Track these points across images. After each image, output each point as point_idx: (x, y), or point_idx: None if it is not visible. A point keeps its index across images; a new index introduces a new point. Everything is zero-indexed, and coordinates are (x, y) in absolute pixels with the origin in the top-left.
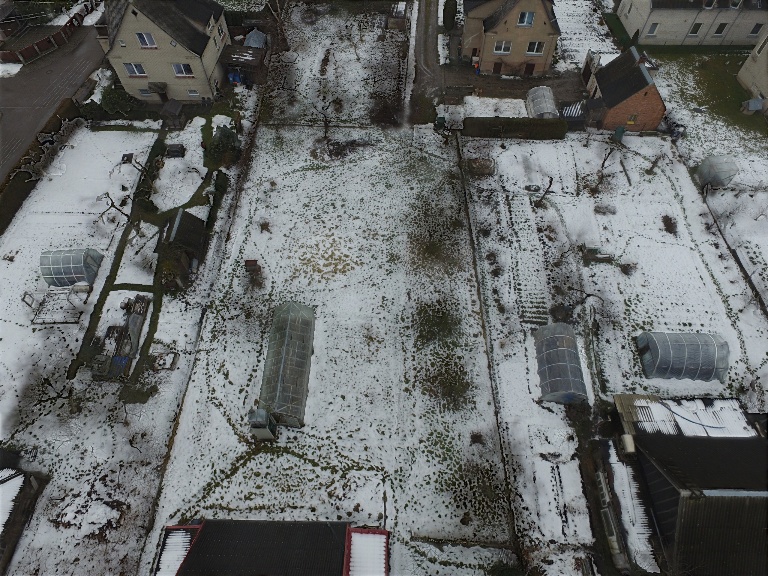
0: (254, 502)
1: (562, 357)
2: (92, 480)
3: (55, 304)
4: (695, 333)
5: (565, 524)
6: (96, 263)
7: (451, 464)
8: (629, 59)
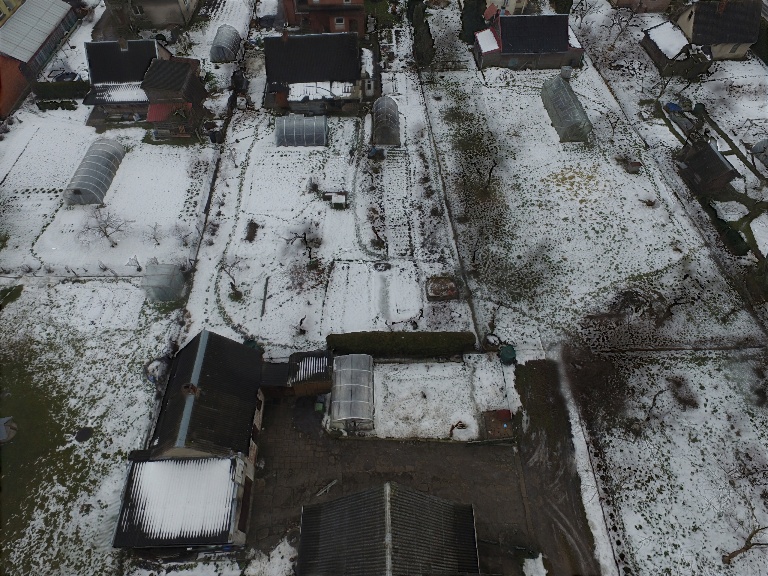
0: (549, 74)
1: (389, 111)
2: (638, 74)
3: (762, 137)
4: (290, 134)
5: (393, 77)
6: (766, 159)
7: (452, 90)
8: (200, 418)
